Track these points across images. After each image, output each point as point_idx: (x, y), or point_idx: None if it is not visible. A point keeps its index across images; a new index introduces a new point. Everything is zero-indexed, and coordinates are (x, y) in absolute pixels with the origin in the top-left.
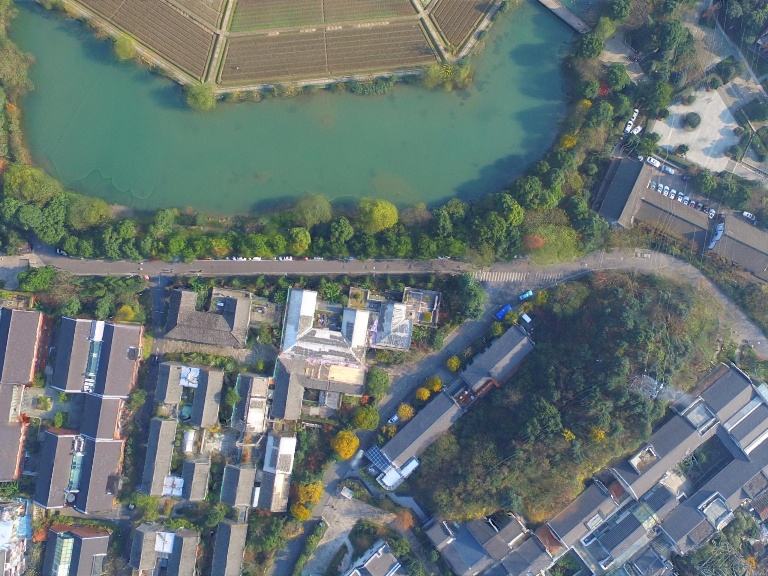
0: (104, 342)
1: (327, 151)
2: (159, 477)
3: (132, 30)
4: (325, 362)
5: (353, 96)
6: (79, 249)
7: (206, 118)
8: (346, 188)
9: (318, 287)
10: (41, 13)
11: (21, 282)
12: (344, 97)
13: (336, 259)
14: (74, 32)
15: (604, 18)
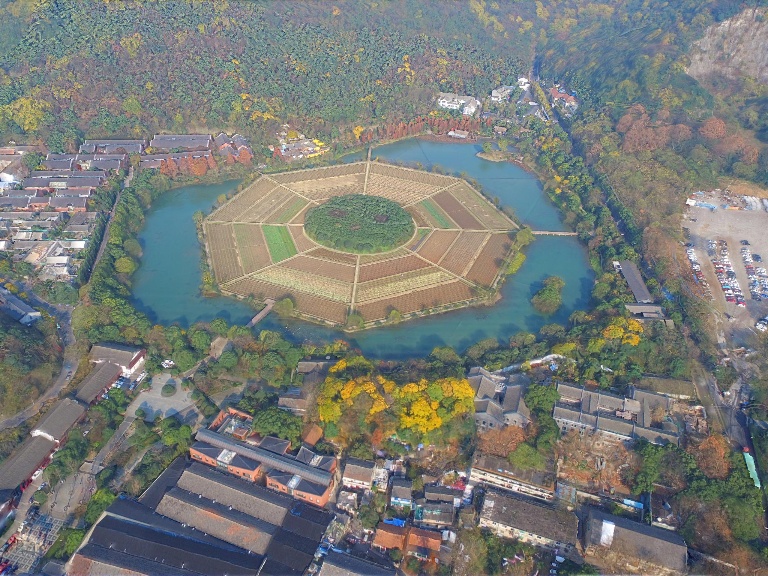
0: None
1: None
2: (4, 215)
3: None
4: (43, 253)
5: None
6: None
7: None
8: None
9: None
10: None
11: None
12: None
13: None
14: (234, 192)
15: (237, 326)
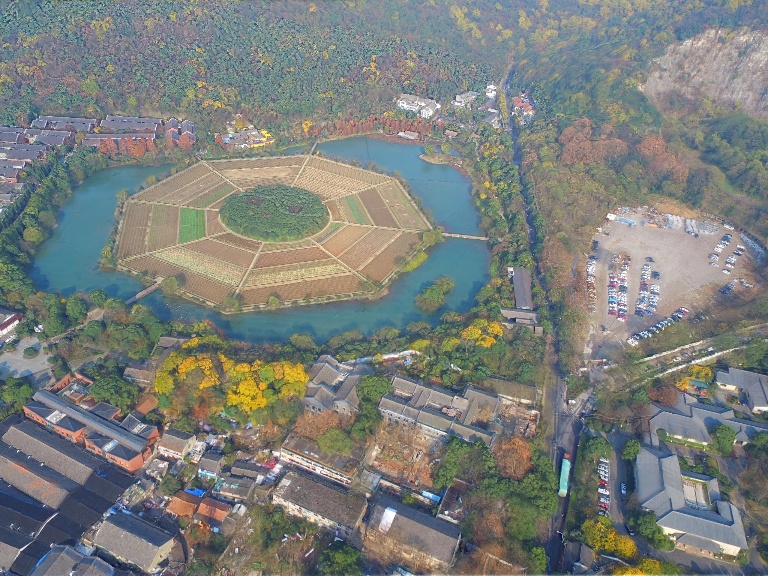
0: None
1: None
2: None
3: None
4: None
5: None
6: None
7: None
8: None
9: (2, 215)
10: None
11: None
12: None
13: None
14: None
15: None
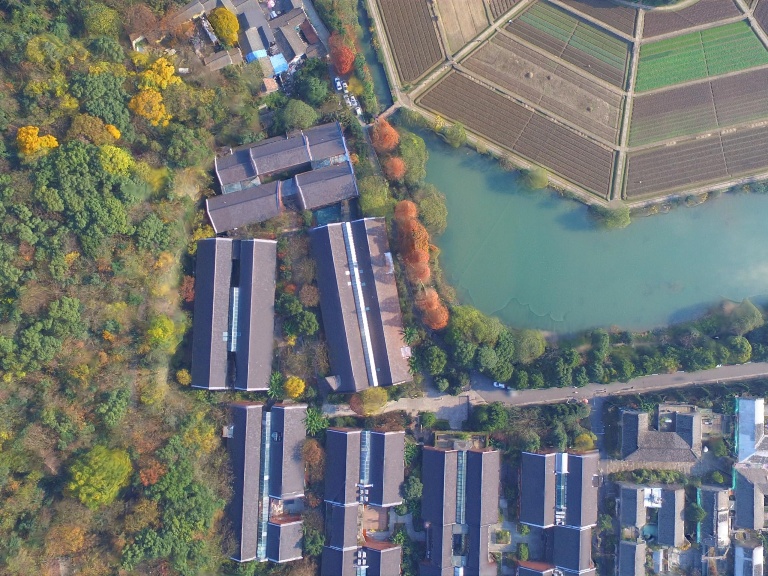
0: (570, 474)
1: (726, 251)
2: None
3: (534, 157)
4: None
5: (754, 196)
6: (533, 384)
7: (616, 235)
8: (745, 284)
9: (765, 394)
10: (443, 150)
11: (484, 424)
12: (746, 198)
13: (765, 361)
14: (477, 165)
15: None
